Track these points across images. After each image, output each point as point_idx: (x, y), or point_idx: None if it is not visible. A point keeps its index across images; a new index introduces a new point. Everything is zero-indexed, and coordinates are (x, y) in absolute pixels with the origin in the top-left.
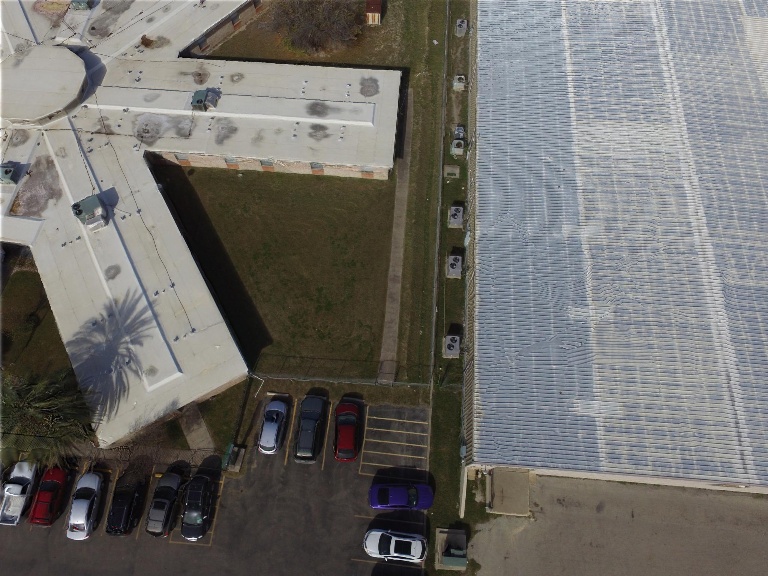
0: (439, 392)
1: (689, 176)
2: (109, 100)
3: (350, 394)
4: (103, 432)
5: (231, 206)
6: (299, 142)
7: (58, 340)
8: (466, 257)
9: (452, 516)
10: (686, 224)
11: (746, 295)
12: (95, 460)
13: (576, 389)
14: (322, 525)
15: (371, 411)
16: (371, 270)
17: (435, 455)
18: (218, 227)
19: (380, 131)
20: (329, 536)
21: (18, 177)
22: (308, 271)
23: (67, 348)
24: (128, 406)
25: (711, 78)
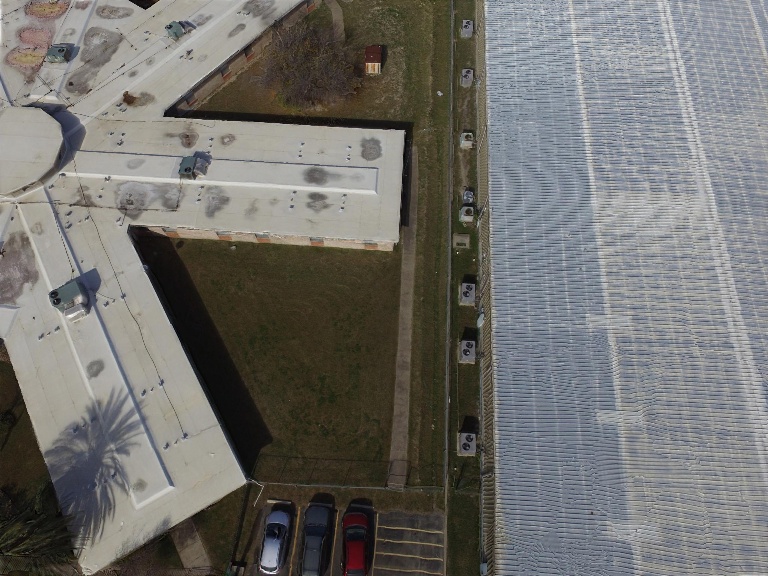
0: (454, 496)
1: (720, 256)
2: (89, 167)
3: (358, 500)
4: (87, 560)
5: (224, 283)
6: (297, 214)
7: (36, 442)
8: (480, 341)
9: None
10: (719, 311)
11: None
12: None
13: None
14: None
15: (381, 520)
16: (377, 355)
17: (452, 571)
18: (210, 308)
19: (384, 200)
20: None
21: None
22: (309, 357)
23: (46, 459)
24: (114, 527)
25: (738, 141)
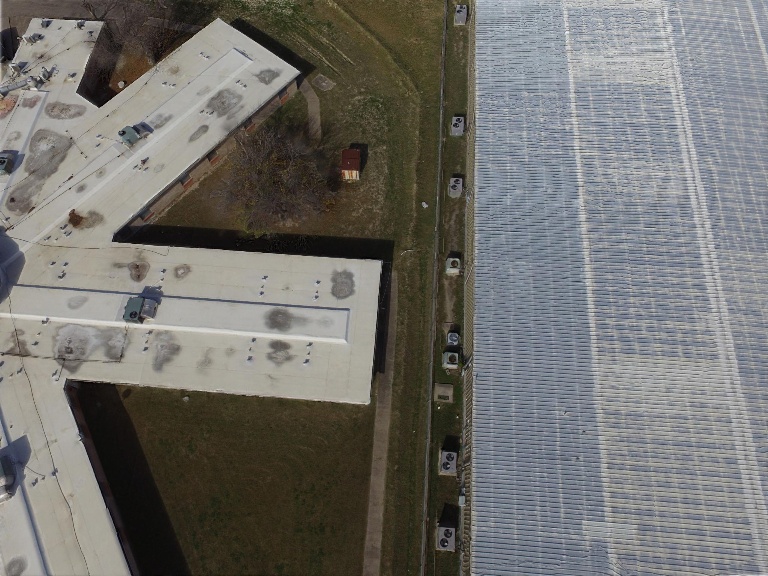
0: None
1: (744, 445)
2: (25, 307)
3: None
4: None
5: (174, 443)
6: (255, 367)
7: None
8: (461, 526)
9: None
10: (742, 520)
11: None
12: None
13: None
14: None
15: None
16: (343, 538)
17: None
18: (157, 474)
19: (355, 350)
20: None
21: None
22: (266, 539)
23: None
24: None
25: (766, 288)
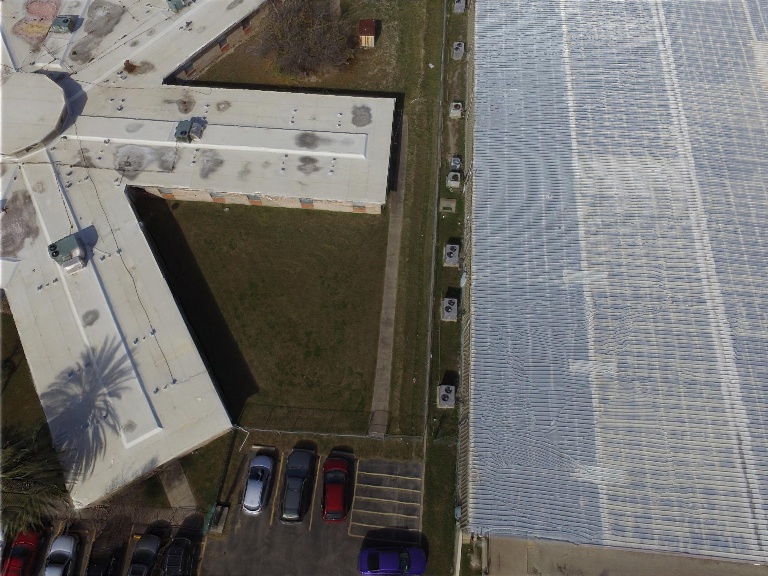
0: (433, 445)
1: (697, 217)
2: (89, 131)
3: (339, 447)
4: (78, 493)
5: (217, 243)
6: (287, 176)
7: (34, 388)
8: (462, 299)
9: None
10: (694, 269)
11: (758, 348)
12: (70, 520)
13: (577, 453)
14: None
15: (361, 466)
16: (362, 312)
17: (428, 515)
18: (203, 265)
19: (372, 164)
20: None
21: None
22: (296, 313)
23: (42, 400)
24: (105, 464)
25: (720, 109)
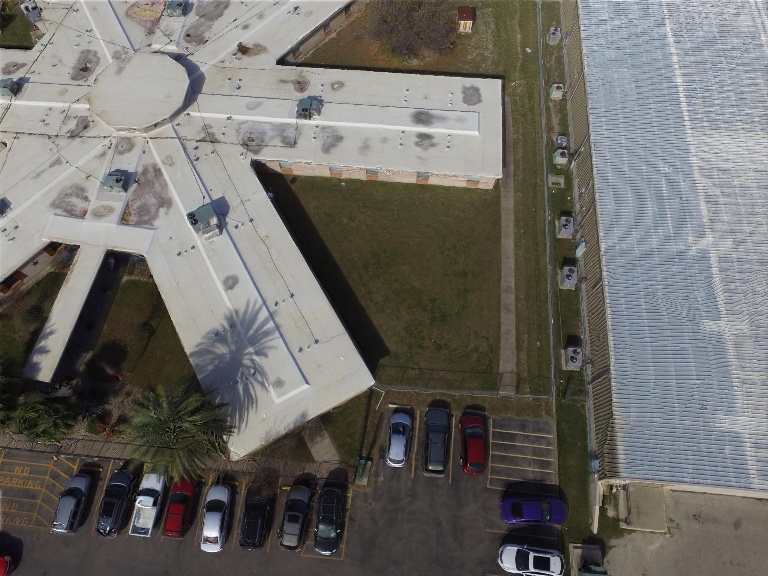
0: (562, 405)
1: None
2: (211, 108)
3: (473, 406)
4: (236, 444)
5: (336, 215)
6: (406, 151)
7: (174, 350)
8: (580, 268)
9: (585, 531)
10: None
11: None
12: (223, 472)
13: (723, 405)
14: (454, 539)
15: (495, 424)
16: (483, 281)
17: (565, 469)
18: (325, 236)
19: (486, 140)
20: (461, 551)
21: (127, 185)
22: (419, 281)
23: (191, 359)
24: (257, 418)
25: None
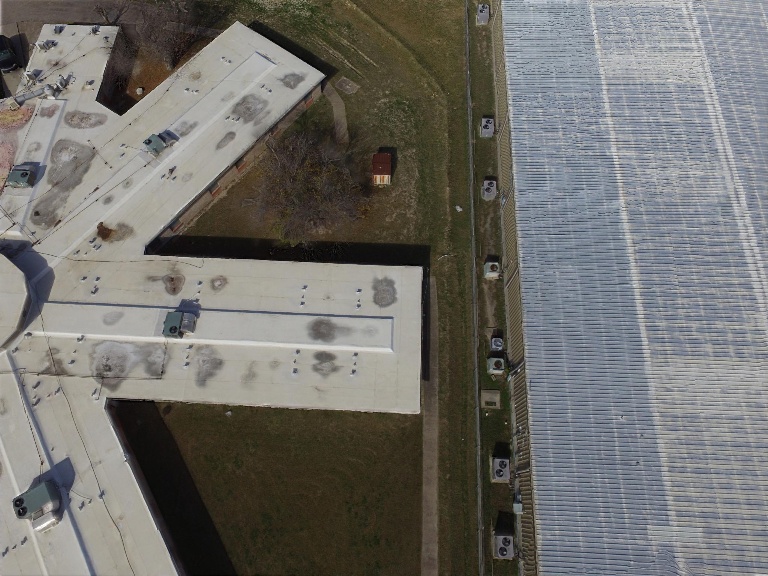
0: None
1: None
2: (59, 324)
3: None
4: None
5: (219, 460)
6: (301, 380)
7: None
8: (518, 534)
9: None
10: None
11: None
12: None
13: None
14: None
15: None
16: (399, 551)
17: None
18: (204, 493)
19: (401, 359)
20: None
21: None
22: (320, 555)
23: None
24: None
25: None
